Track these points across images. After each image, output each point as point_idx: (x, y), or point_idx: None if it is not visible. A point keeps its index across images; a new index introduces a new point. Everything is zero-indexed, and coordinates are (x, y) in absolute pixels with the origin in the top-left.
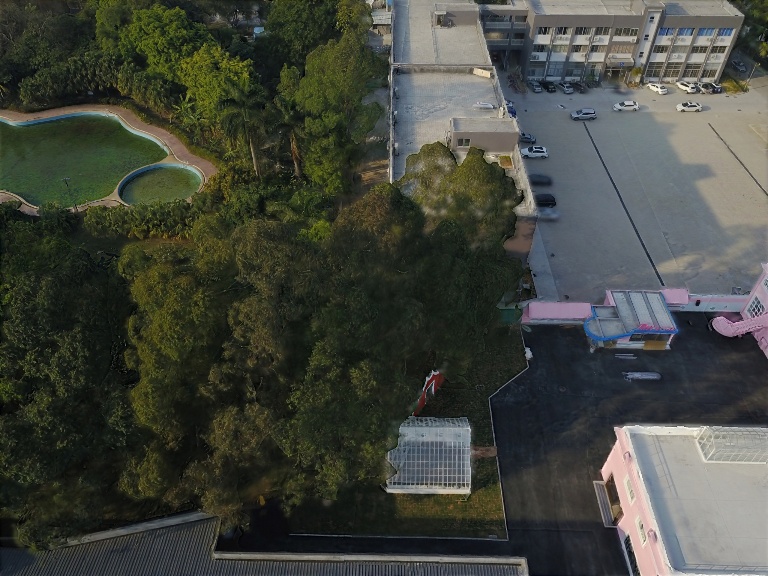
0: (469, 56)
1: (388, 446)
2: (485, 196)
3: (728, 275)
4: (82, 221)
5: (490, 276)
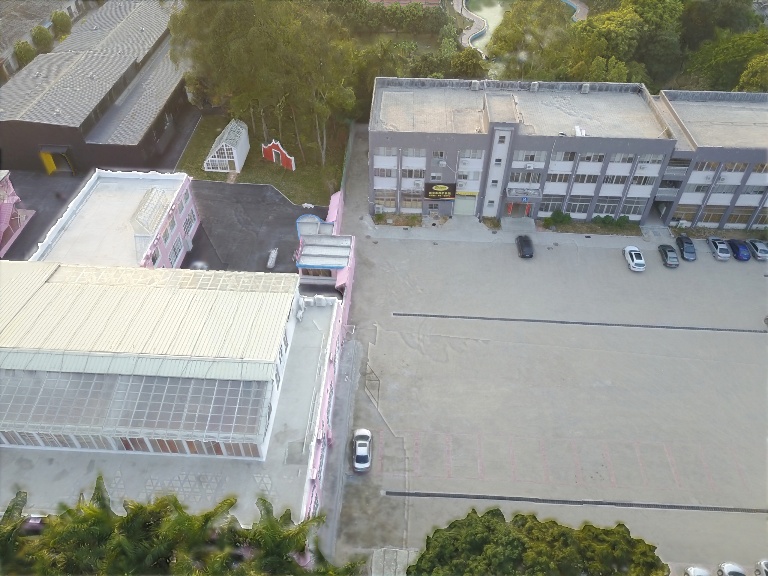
0: (735, 145)
1: None
2: (255, 0)
3: (408, 372)
4: (458, 51)
5: (233, 42)
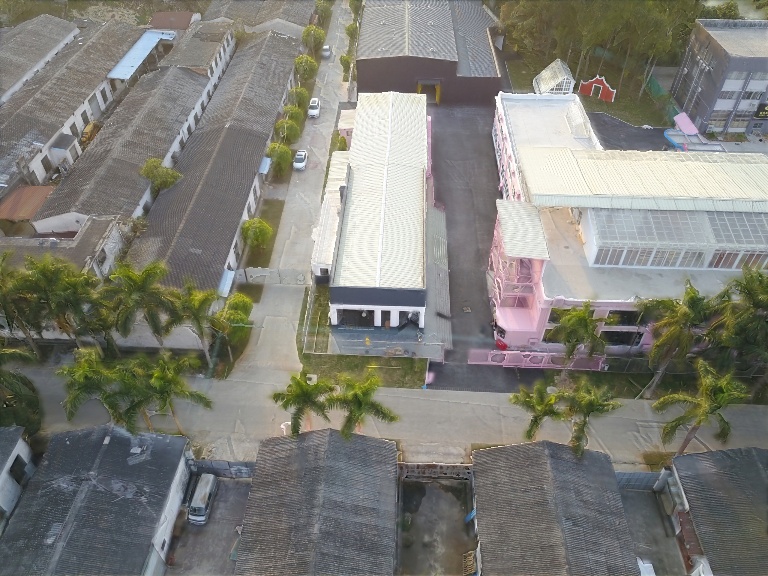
0: None
1: (524, 2)
2: None
3: None
4: None
5: None
